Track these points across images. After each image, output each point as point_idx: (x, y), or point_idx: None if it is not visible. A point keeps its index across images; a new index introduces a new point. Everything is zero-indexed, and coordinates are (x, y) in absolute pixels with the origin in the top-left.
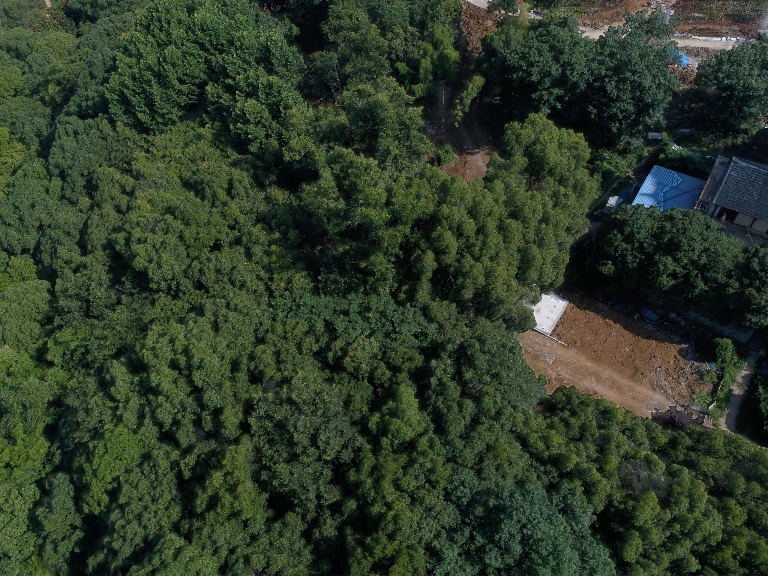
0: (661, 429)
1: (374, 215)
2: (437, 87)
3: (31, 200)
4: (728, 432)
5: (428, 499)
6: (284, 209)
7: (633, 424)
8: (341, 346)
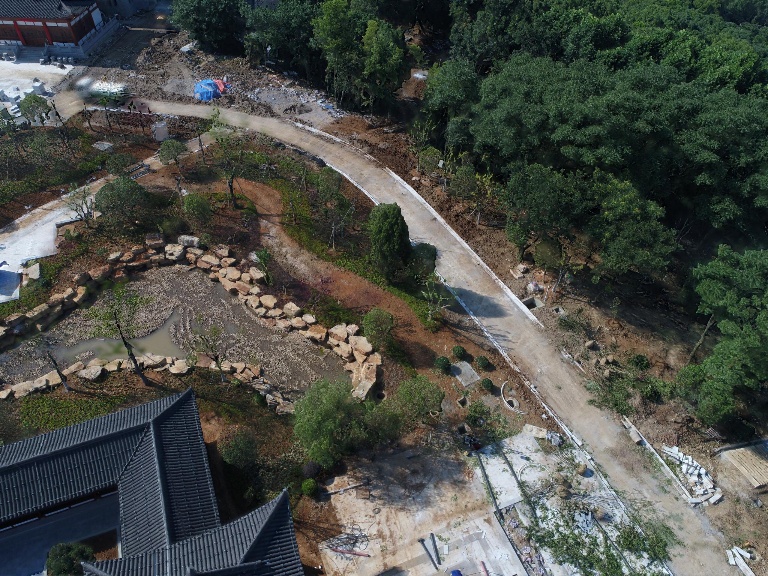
0: None
1: None
2: (442, 126)
3: None
4: None
5: None
6: None
7: None
8: None
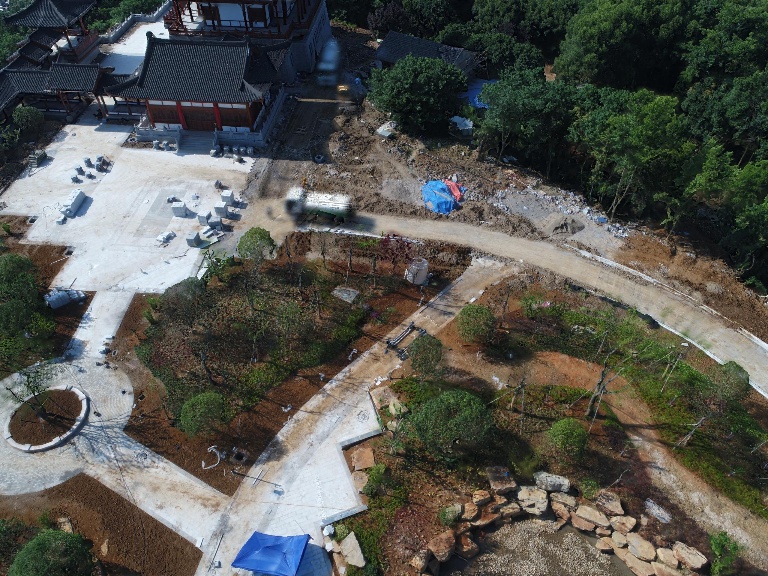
0: (528, 7)
1: None
2: None
3: None
4: (504, 3)
5: None
6: None
7: (542, 1)
8: None
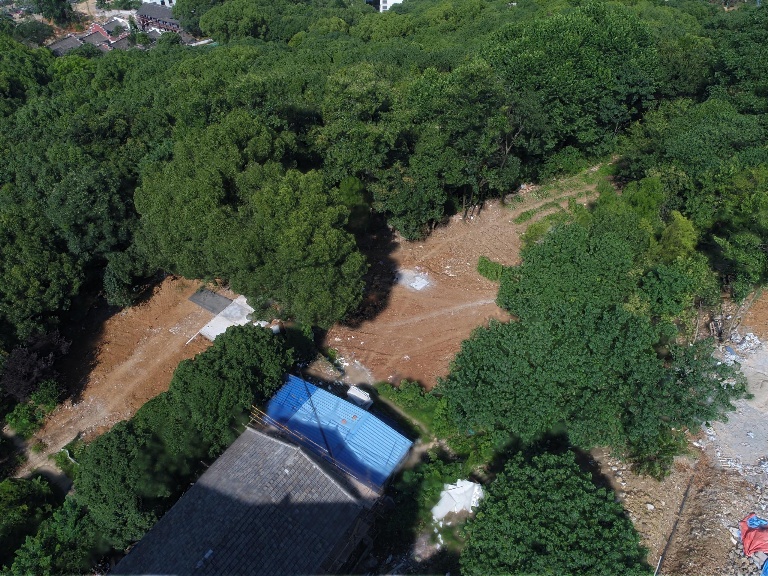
0: None
1: (177, 84)
2: None
3: (397, 56)
4: None
5: (2, 160)
6: (294, 108)
7: (5, 280)
8: (147, 141)
